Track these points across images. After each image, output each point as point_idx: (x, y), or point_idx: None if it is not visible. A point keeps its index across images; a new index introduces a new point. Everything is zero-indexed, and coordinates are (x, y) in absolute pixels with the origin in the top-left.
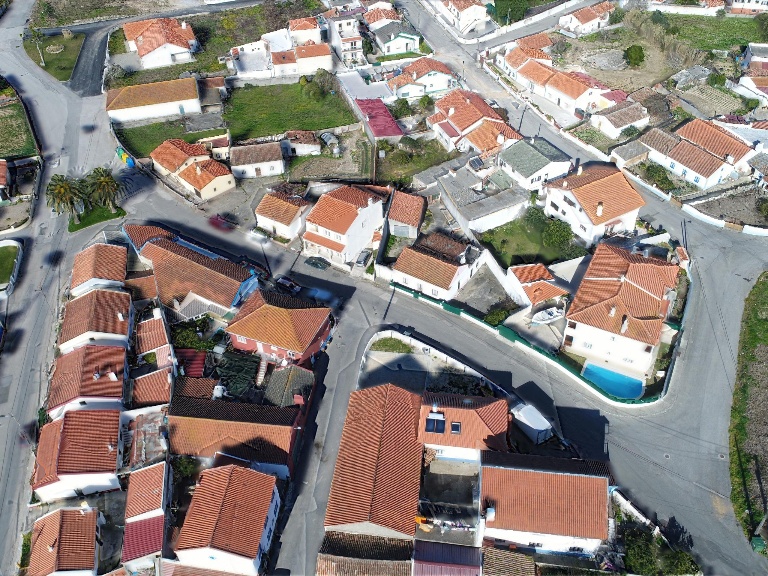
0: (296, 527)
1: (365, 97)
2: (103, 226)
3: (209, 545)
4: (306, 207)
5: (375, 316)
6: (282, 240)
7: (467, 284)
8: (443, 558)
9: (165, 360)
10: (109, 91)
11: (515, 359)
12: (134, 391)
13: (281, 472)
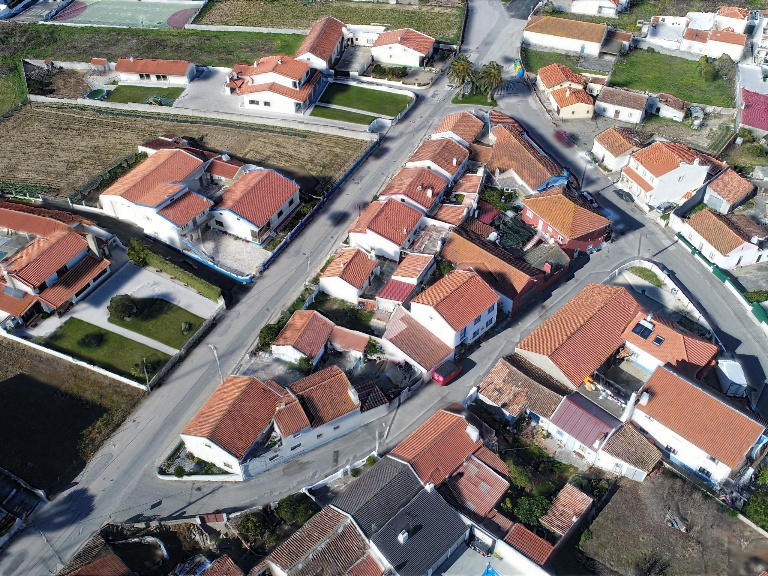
0: (496, 343)
1: (754, 90)
2: (476, 108)
3: (434, 306)
4: (639, 149)
5: (647, 251)
6: (605, 168)
7: (749, 266)
8: (589, 409)
9: (469, 202)
10: (533, 17)
11: (753, 335)
12: (438, 211)
13: (506, 304)
